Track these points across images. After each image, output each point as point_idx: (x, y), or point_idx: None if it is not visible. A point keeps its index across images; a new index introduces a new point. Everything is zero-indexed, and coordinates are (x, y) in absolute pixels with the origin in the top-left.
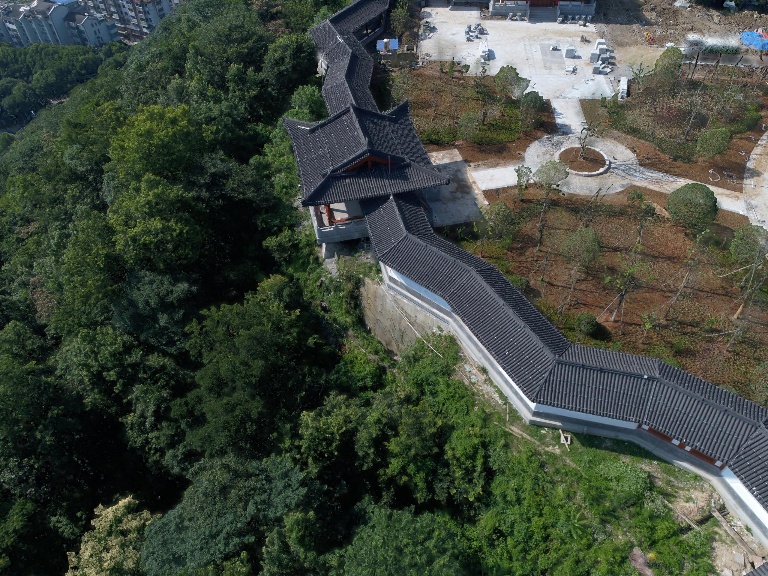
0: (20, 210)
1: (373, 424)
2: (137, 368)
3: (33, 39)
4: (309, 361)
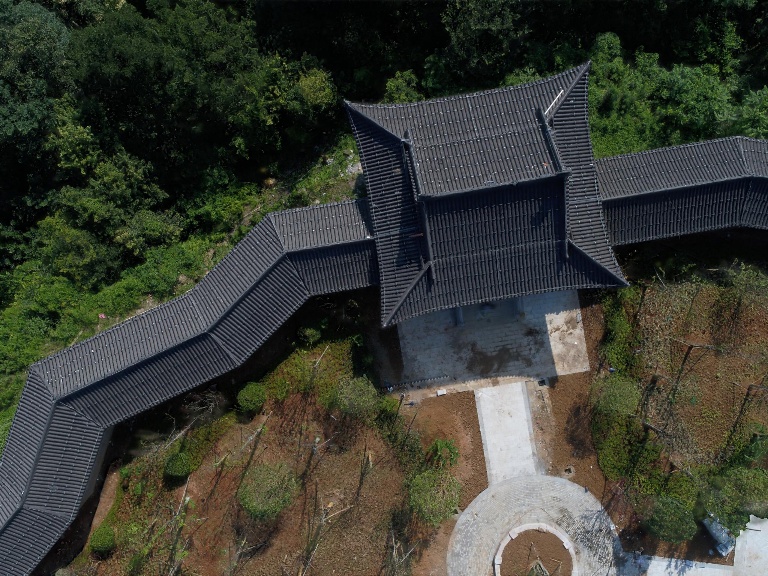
0: None
1: None
2: None
3: None
4: None
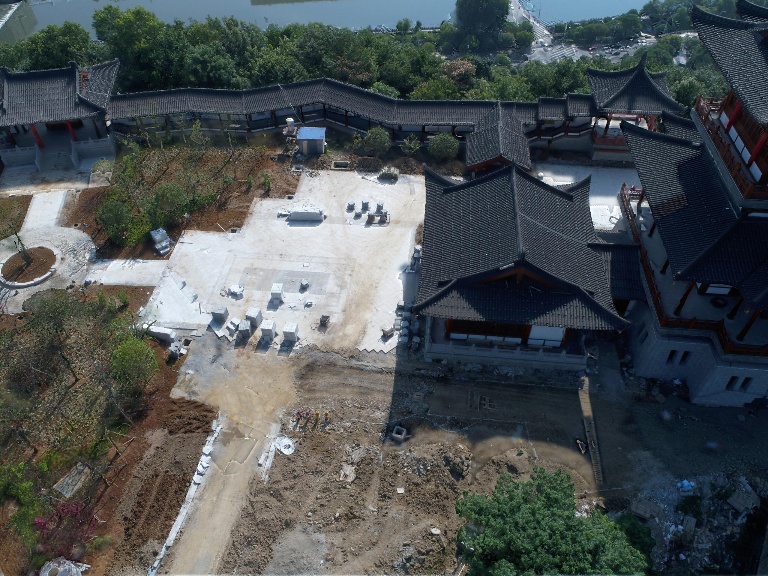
0: None
1: None
2: None
3: None
4: None
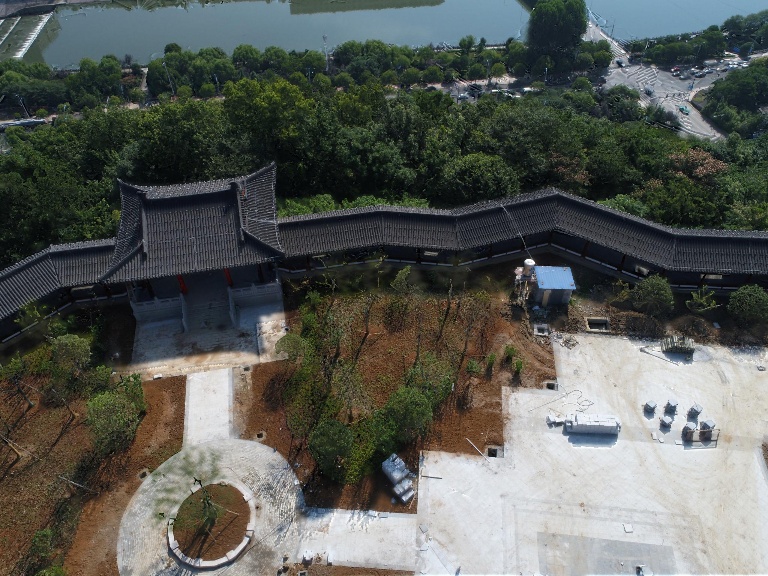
0: None
1: None
2: None
3: None
4: None
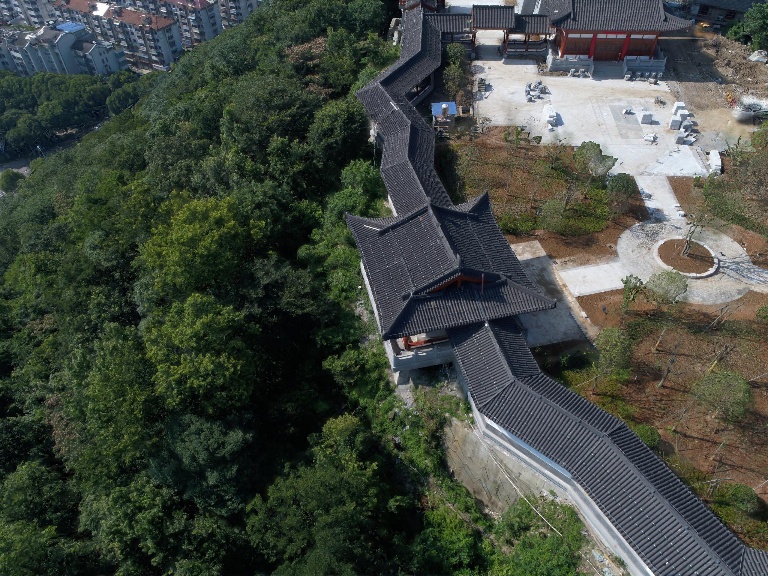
0: (32, 299)
1: None
2: (180, 537)
3: (39, 68)
4: (386, 521)
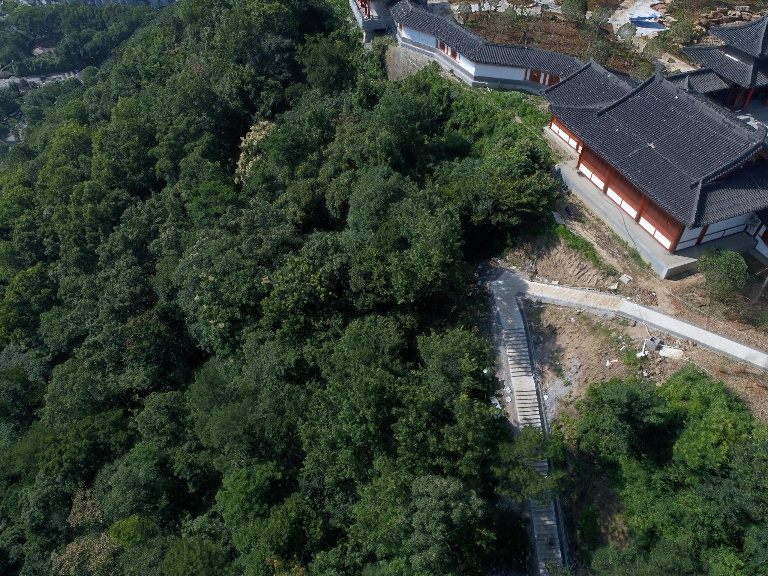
0: None
1: (393, 84)
2: (262, 84)
3: (105, 2)
4: None
